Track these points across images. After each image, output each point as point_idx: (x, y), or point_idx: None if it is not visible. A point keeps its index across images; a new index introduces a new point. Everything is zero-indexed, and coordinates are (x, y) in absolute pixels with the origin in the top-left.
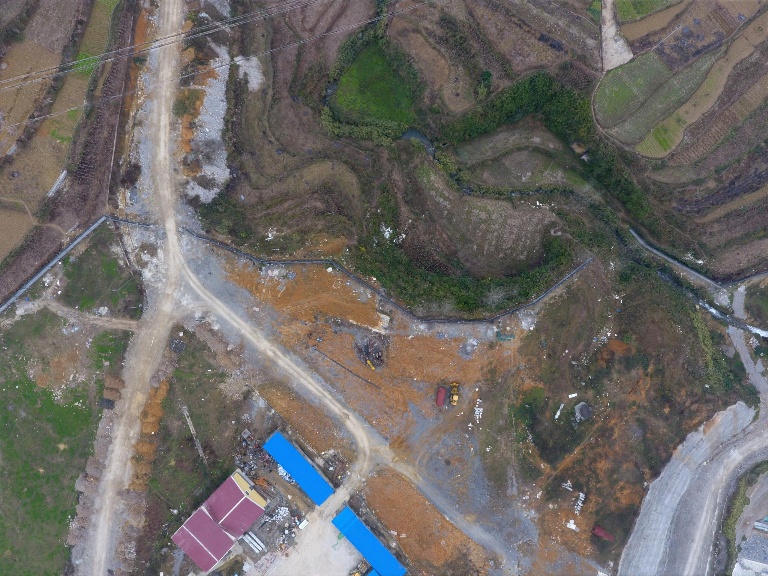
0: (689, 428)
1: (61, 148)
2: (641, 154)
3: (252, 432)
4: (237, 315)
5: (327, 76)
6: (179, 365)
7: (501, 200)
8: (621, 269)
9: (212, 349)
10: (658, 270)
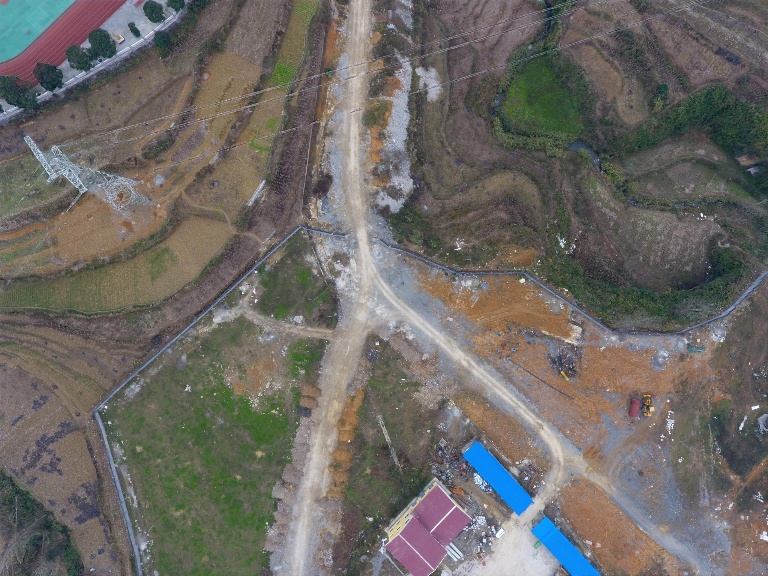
0: None
1: (260, 158)
2: None
3: (448, 441)
4: (431, 325)
5: (496, 87)
6: (373, 374)
7: (666, 211)
8: None
9: (406, 358)
10: None
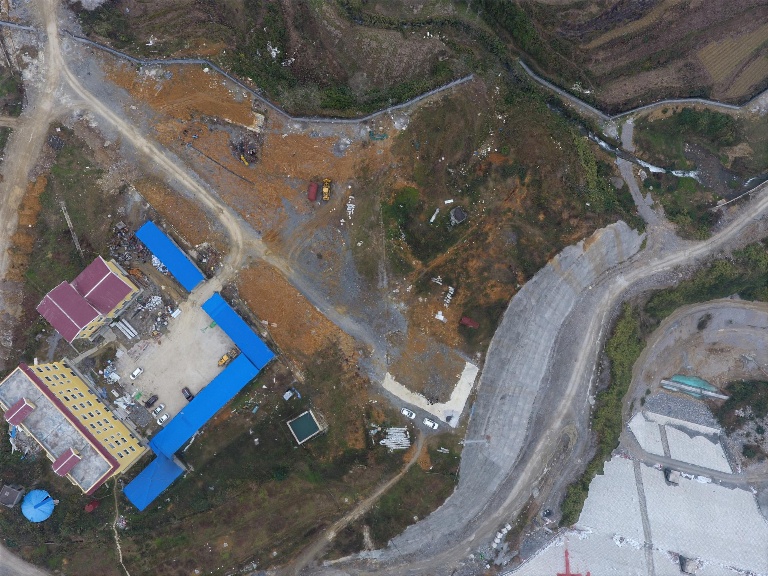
0: (568, 242)
1: None
2: None
3: (127, 225)
4: (114, 113)
5: None
6: (58, 162)
7: (392, 30)
8: (508, 97)
9: (90, 146)
10: (548, 102)
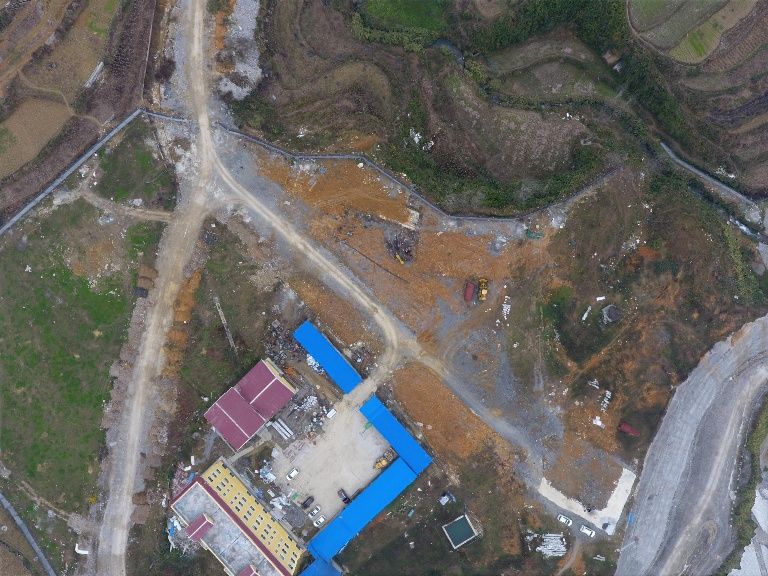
0: (717, 337)
1: (98, 40)
2: (676, 59)
3: (282, 323)
4: (268, 208)
5: None
6: (211, 257)
7: (531, 111)
8: (651, 181)
9: (243, 242)
10: (688, 185)
